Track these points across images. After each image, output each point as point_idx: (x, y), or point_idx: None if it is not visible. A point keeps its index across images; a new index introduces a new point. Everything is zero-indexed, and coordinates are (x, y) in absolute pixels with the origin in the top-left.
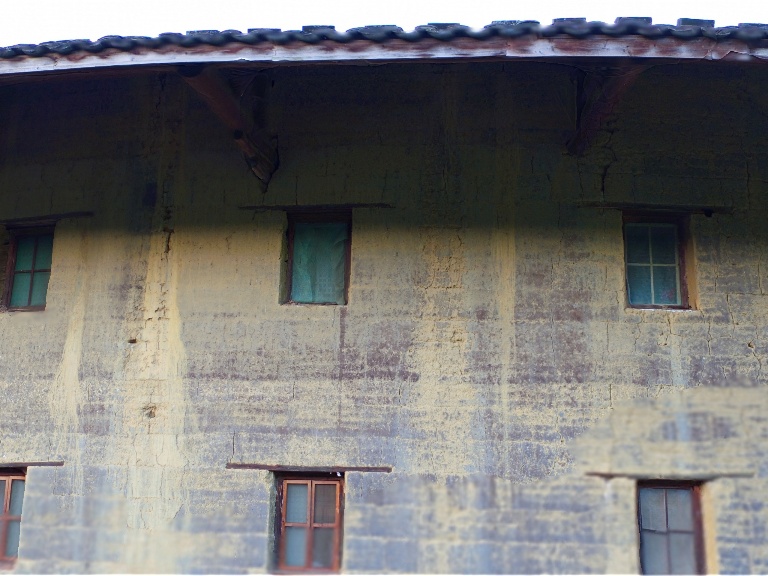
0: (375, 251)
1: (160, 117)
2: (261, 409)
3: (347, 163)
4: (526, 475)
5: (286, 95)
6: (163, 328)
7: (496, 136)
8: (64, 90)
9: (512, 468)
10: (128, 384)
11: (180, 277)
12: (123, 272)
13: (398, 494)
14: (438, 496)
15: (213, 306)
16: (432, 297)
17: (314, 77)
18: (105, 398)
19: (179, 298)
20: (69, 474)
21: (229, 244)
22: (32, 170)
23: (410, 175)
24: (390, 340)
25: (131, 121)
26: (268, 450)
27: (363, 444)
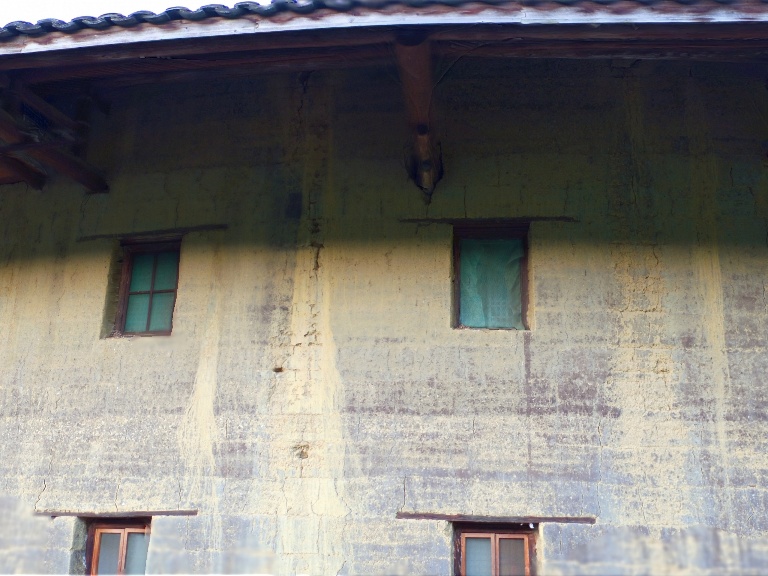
0: (560, 269)
1: (303, 122)
2: (436, 448)
3: (522, 172)
4: (754, 528)
5: (448, 99)
6: (315, 355)
7: (688, 145)
8: (189, 93)
9: (737, 519)
10: (274, 419)
11: (333, 297)
12: (265, 291)
13: (605, 550)
14: (653, 552)
15: (373, 330)
16: (629, 321)
17: (479, 80)
18: (247, 435)
19: (333, 321)
20: (204, 525)
21: (389, 260)
22: (153, 179)
23: (595, 186)
24: (584, 370)
25: (269, 126)
26: (446, 497)
27: (559, 490)
